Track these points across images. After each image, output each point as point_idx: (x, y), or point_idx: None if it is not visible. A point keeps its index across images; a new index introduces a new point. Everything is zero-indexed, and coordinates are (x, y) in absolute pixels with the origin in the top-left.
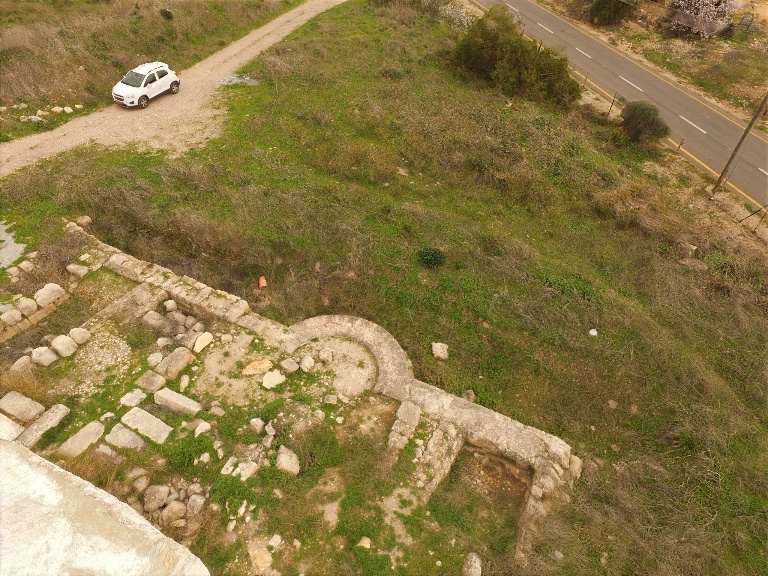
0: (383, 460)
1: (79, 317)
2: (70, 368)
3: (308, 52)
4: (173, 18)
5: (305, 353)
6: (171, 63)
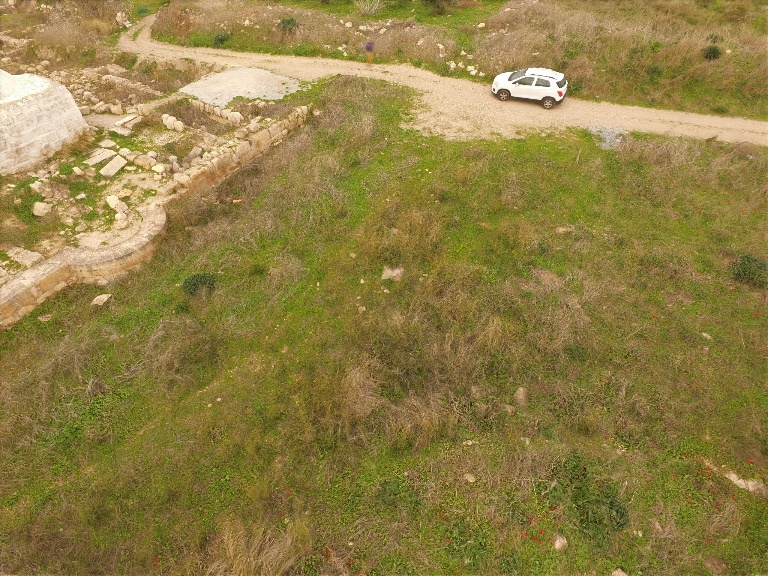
0: (6, 244)
1: (213, 130)
2: (159, 131)
3: (767, 175)
4: (717, 61)
5: (133, 216)
6: (612, 91)
